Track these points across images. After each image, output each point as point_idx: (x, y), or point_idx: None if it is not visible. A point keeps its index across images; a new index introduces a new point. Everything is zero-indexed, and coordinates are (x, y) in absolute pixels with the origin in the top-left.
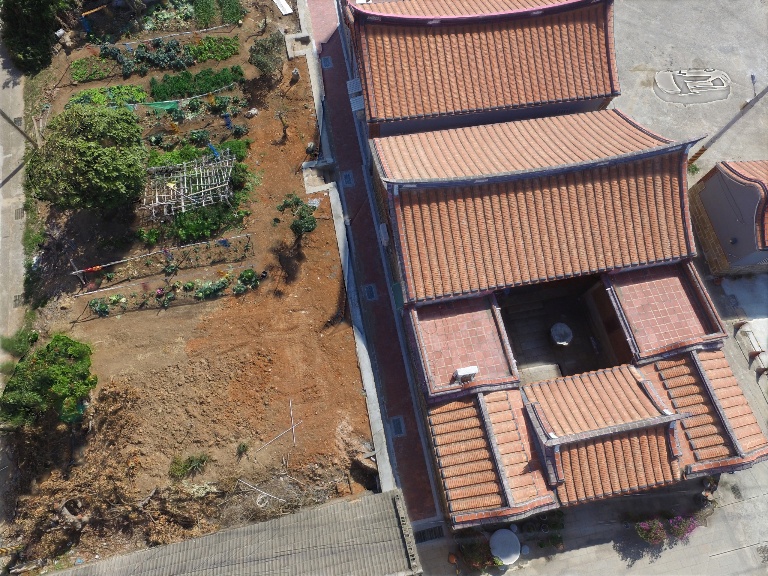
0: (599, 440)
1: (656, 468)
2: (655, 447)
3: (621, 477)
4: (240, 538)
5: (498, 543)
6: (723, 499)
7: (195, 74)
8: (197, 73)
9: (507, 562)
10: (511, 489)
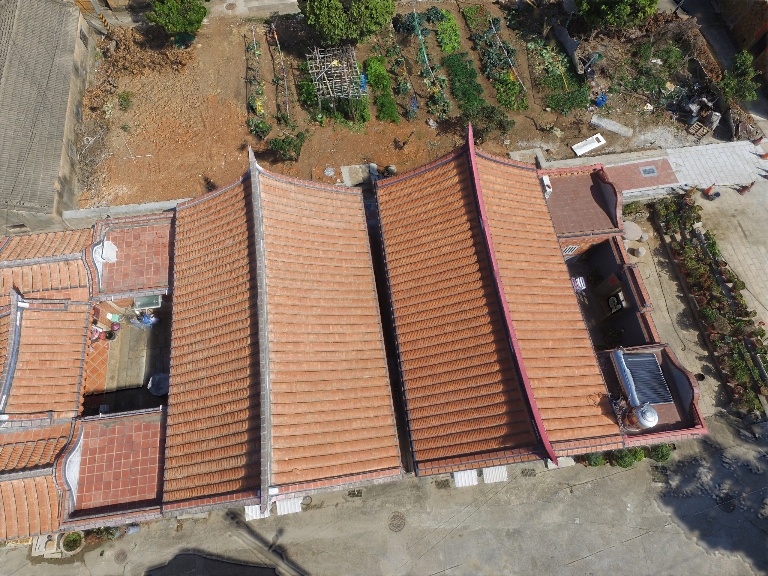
0: None
1: None
2: None
3: None
4: (57, 118)
5: None
6: None
7: (477, 81)
8: (479, 83)
9: None
10: (3, 271)
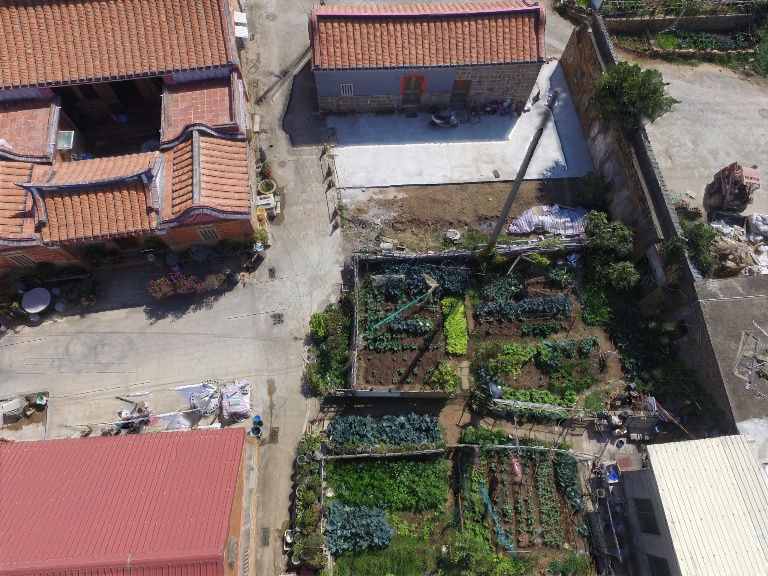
0: (83, 192)
1: (135, 219)
2: (135, 201)
3: (102, 224)
4: None
5: (31, 297)
6: (258, 278)
7: None
8: None
9: (32, 310)
10: None
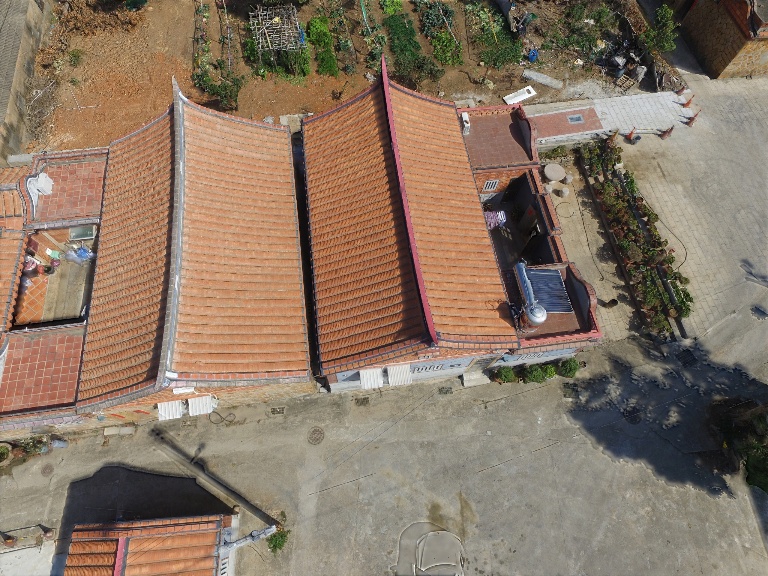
0: None
1: None
2: None
3: None
4: (6, 70)
5: None
6: None
7: (416, 40)
8: (417, 41)
9: None
10: None
